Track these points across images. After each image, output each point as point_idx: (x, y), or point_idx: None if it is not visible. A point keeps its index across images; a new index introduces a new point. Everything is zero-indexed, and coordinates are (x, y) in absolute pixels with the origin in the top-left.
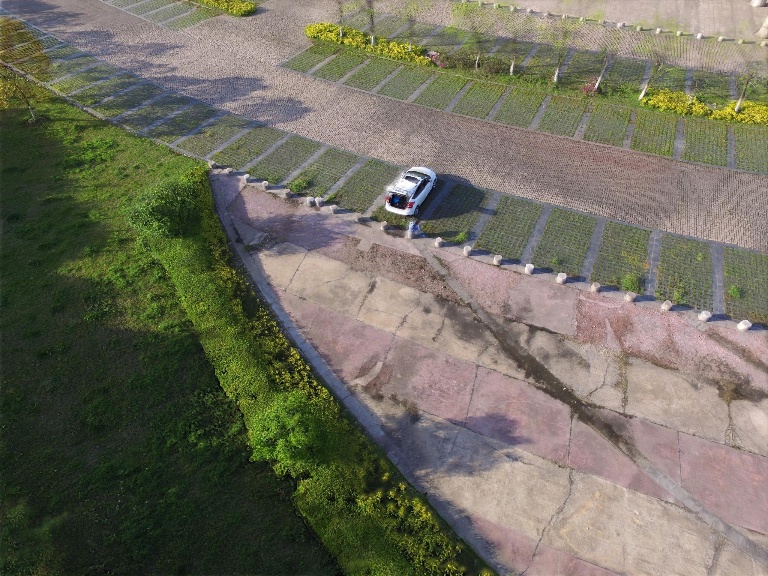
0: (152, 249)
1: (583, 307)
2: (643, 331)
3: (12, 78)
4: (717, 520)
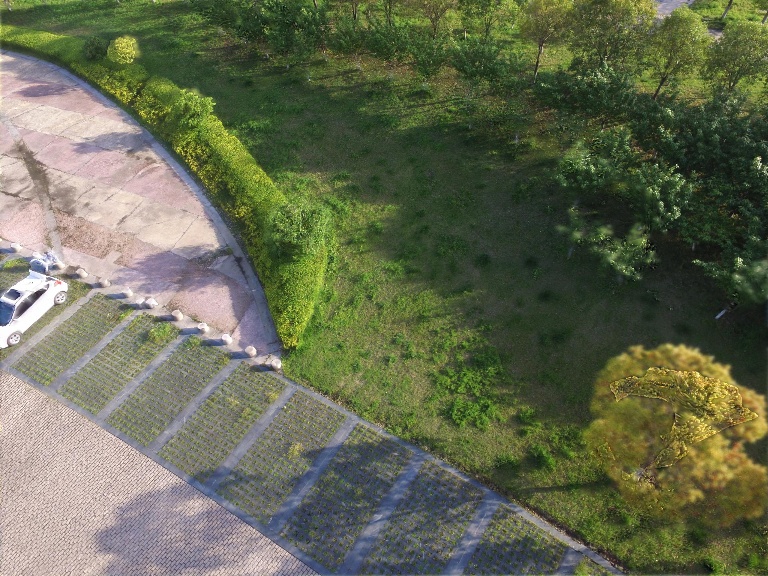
0: None
1: None
2: None
3: None
4: (5, 123)
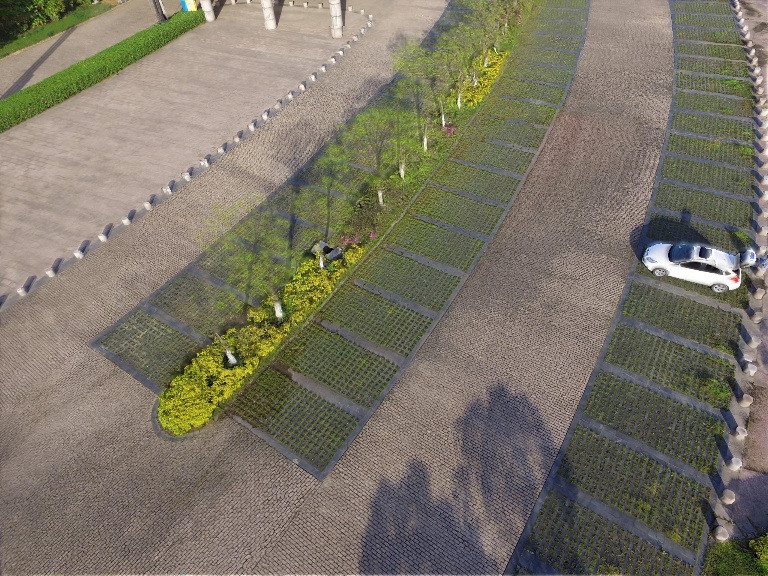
0: None
1: None
2: None
3: None
4: None
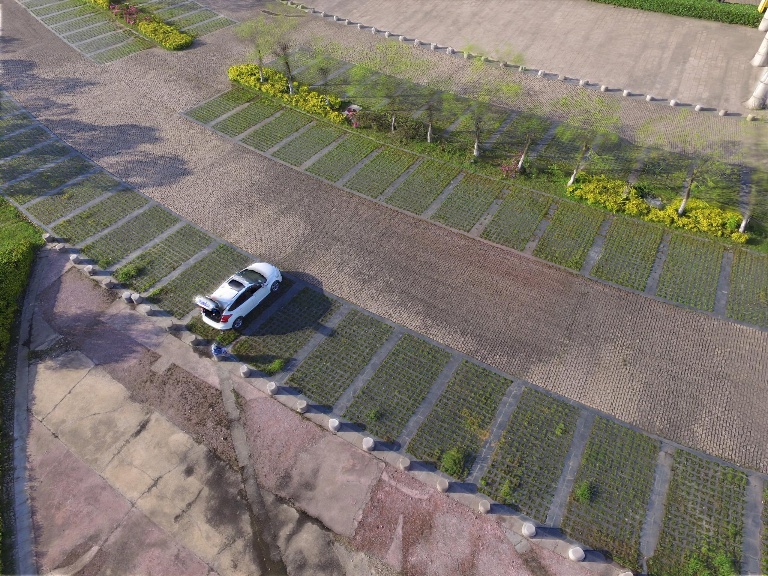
0: None
1: (379, 492)
2: (441, 542)
3: None
4: None
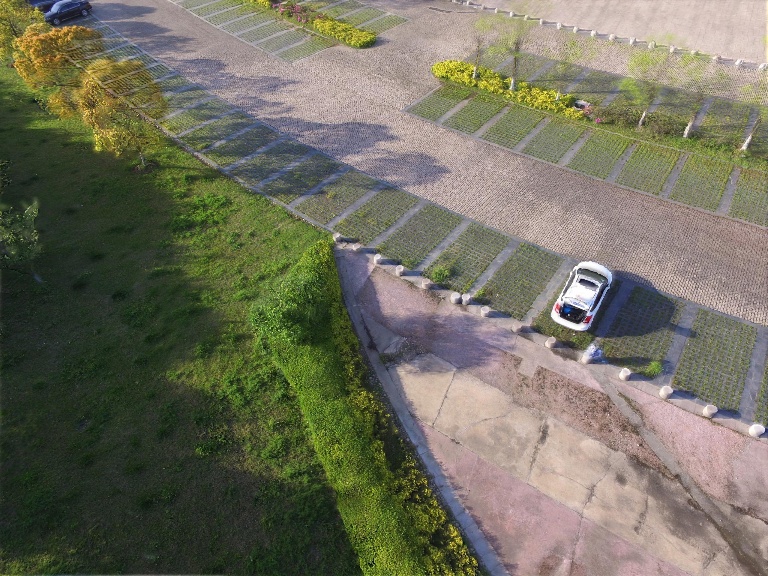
0: (274, 355)
1: None
2: None
3: (127, 123)
4: None
